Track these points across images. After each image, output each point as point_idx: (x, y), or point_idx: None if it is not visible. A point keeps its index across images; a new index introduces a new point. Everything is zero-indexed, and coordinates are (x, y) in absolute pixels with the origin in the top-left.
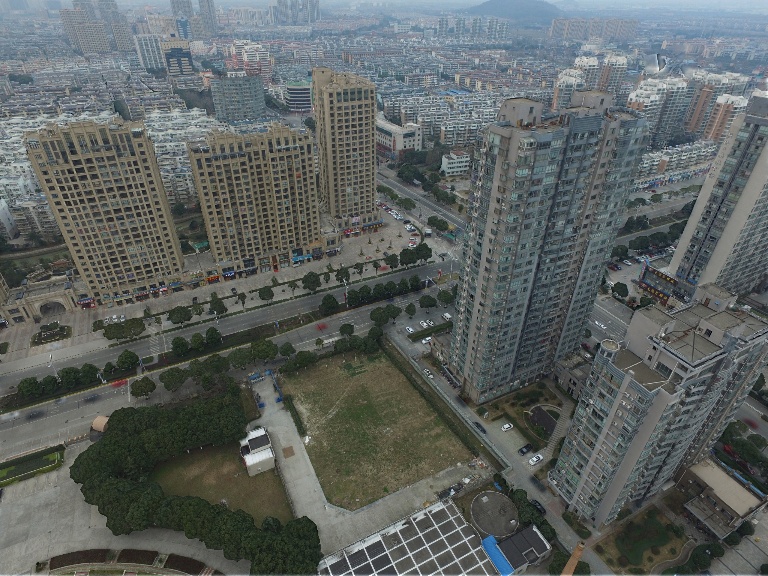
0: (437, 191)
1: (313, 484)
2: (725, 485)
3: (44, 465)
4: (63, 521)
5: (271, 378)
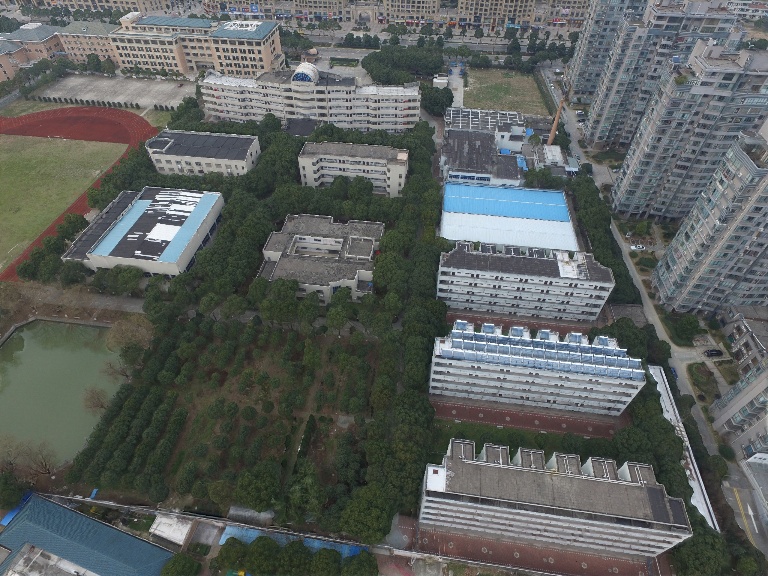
0: None
1: (460, 100)
2: None
3: (350, 64)
4: None
5: (461, 67)
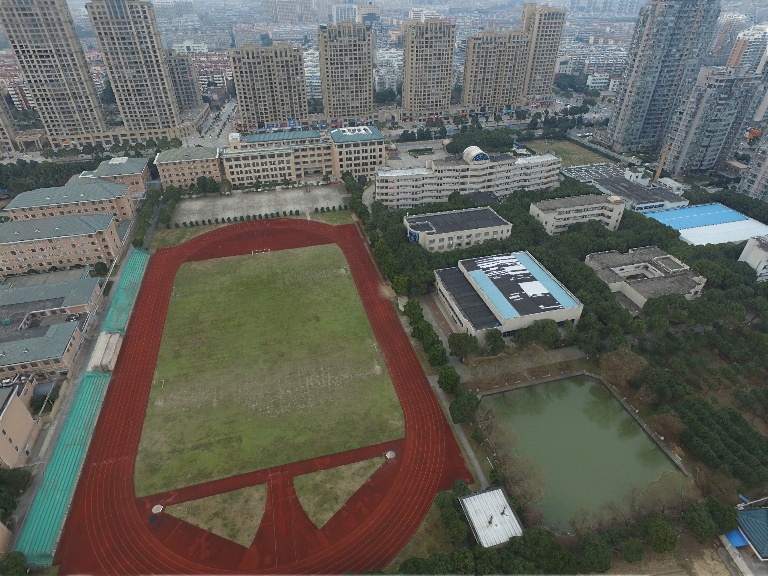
0: (587, 90)
1: None
2: (739, 164)
3: (428, 153)
4: None
5: None
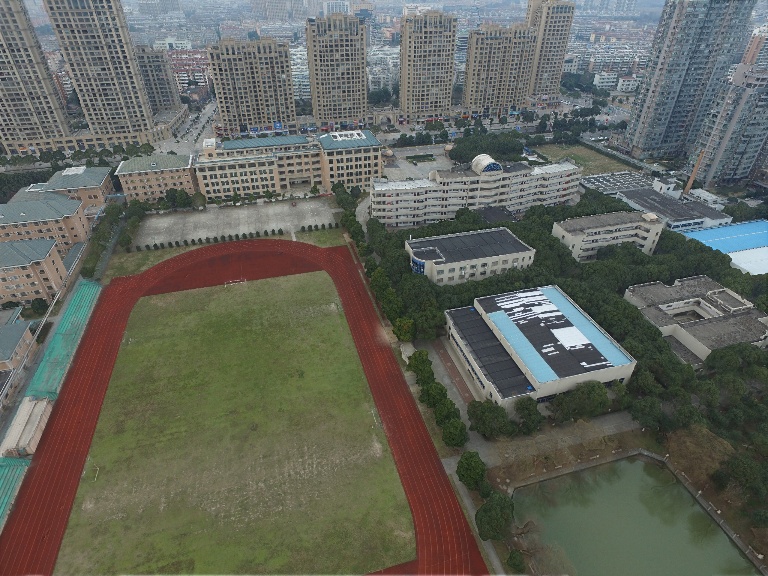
0: (596, 90)
1: None
2: None
3: (428, 159)
4: None
5: None
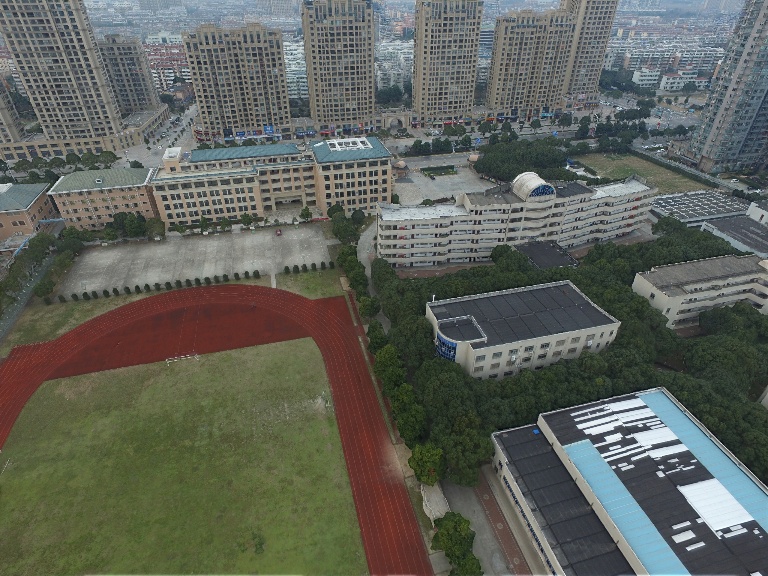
0: (638, 89)
1: None
2: None
3: (448, 172)
4: (476, 187)
5: None
